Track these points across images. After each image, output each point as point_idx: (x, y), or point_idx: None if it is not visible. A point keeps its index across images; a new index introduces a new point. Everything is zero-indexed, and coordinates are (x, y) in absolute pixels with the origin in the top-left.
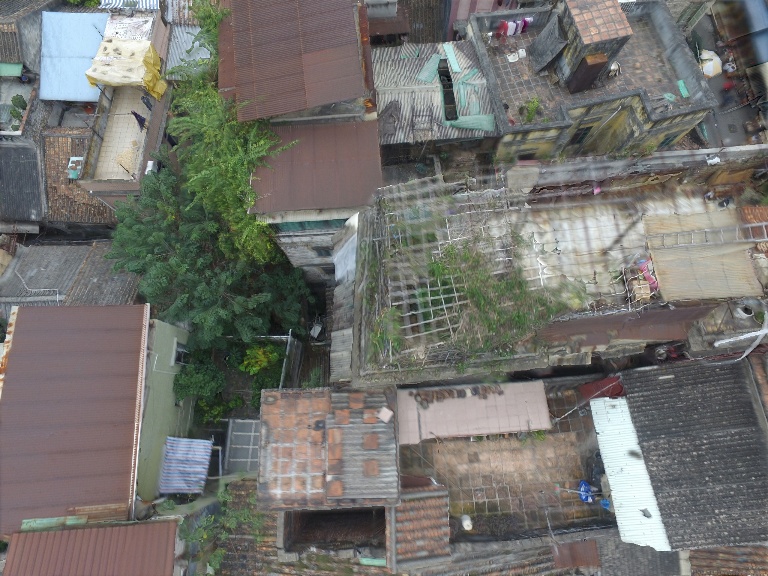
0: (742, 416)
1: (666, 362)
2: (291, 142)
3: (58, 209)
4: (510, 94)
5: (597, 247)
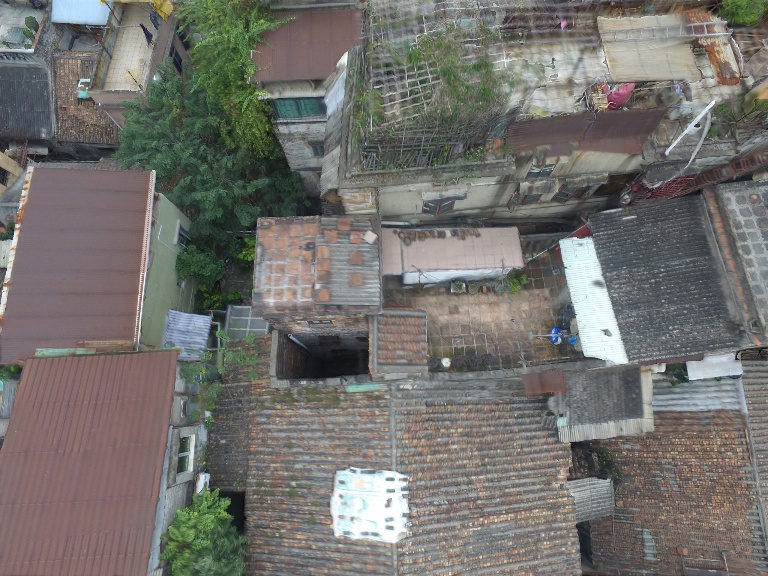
0: (697, 247)
1: (630, 205)
2: (289, 18)
3: (67, 129)
4: (498, 4)
5: (563, 76)
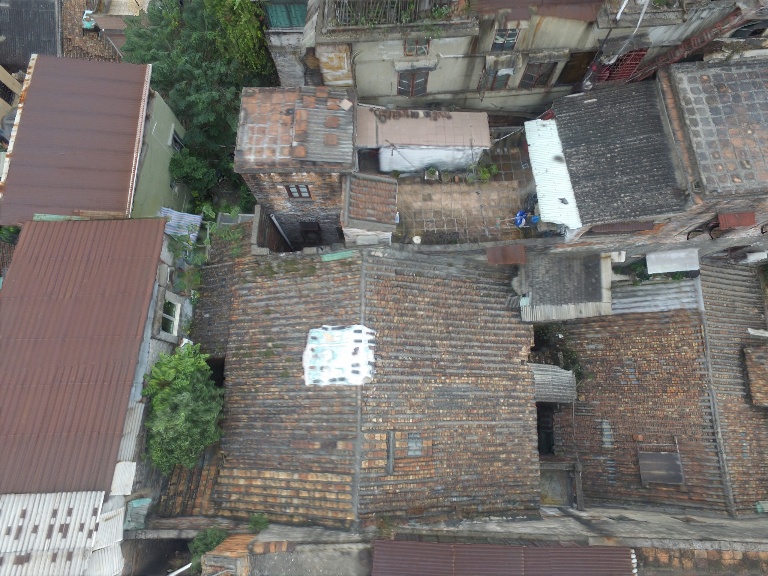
0: (651, 126)
1: (591, 90)
2: None
3: None
4: None
5: None
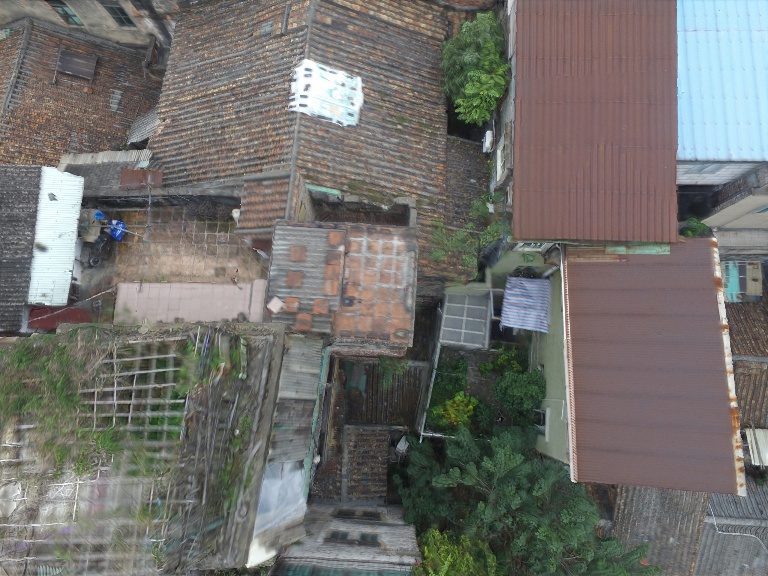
0: None
1: None
2: None
3: None
4: None
5: None
